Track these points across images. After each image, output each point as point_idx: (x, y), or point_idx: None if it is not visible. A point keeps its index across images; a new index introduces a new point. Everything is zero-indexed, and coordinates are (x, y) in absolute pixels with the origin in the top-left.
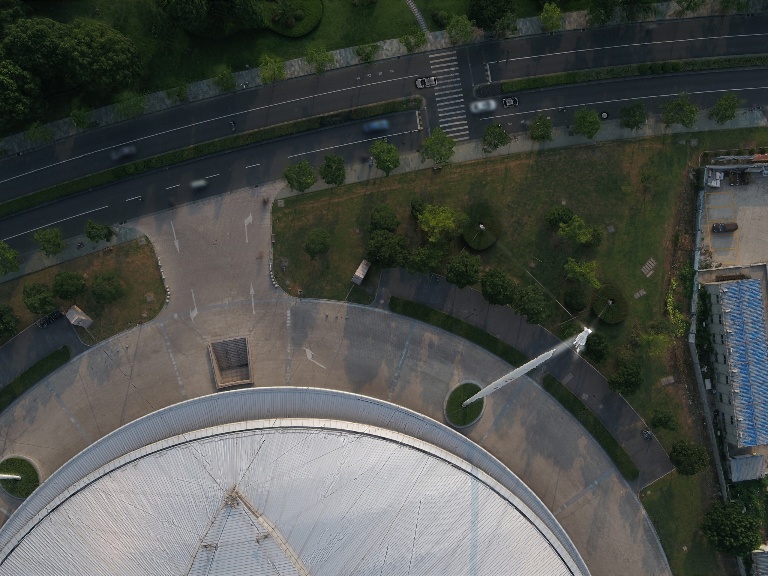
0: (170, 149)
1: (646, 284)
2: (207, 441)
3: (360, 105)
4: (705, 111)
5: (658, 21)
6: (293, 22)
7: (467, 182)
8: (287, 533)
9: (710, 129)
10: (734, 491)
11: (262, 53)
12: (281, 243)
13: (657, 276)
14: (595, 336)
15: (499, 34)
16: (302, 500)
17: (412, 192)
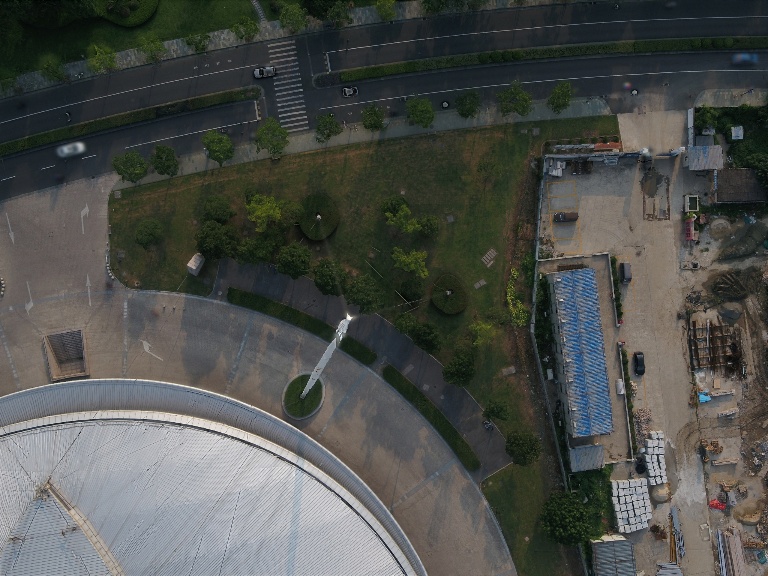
0: (5, 140)
1: (486, 274)
2: (26, 434)
3: (197, 95)
4: (546, 100)
5: (499, 9)
6: (127, 12)
7: (306, 172)
8: (99, 525)
9: (552, 118)
10: (575, 481)
11: (98, 43)
12: (118, 235)
13: (498, 266)
14: (426, 326)
15: (337, 23)
16: (119, 492)
17: (250, 183)
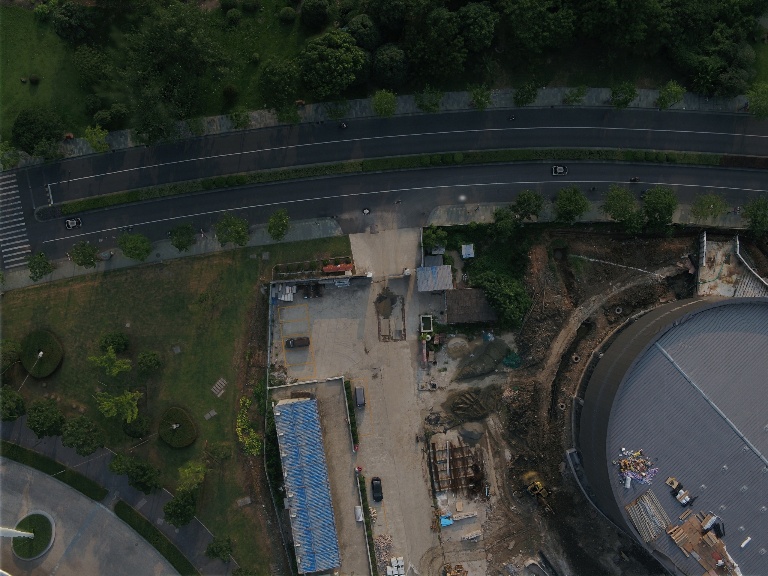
0: None
1: (217, 404)
2: None
3: None
4: None
5: (224, 133)
6: None
7: (30, 308)
8: None
9: (282, 241)
10: None
11: None
12: None
13: (228, 395)
14: (139, 468)
15: None
16: None
17: None
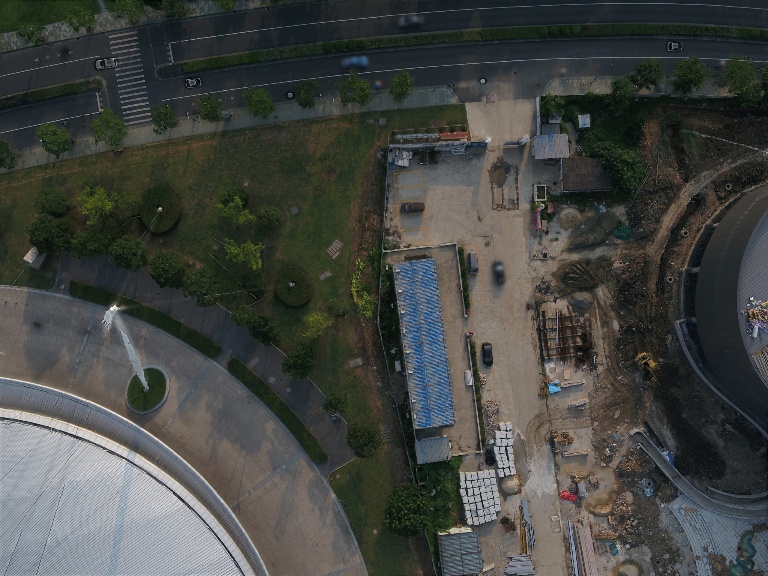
0: None
1: (332, 266)
2: None
3: (38, 87)
4: None
5: None
6: None
7: (148, 164)
8: None
9: (399, 108)
10: (423, 473)
11: None
12: None
13: (343, 257)
14: (261, 318)
15: (178, 13)
16: None
17: (92, 175)
